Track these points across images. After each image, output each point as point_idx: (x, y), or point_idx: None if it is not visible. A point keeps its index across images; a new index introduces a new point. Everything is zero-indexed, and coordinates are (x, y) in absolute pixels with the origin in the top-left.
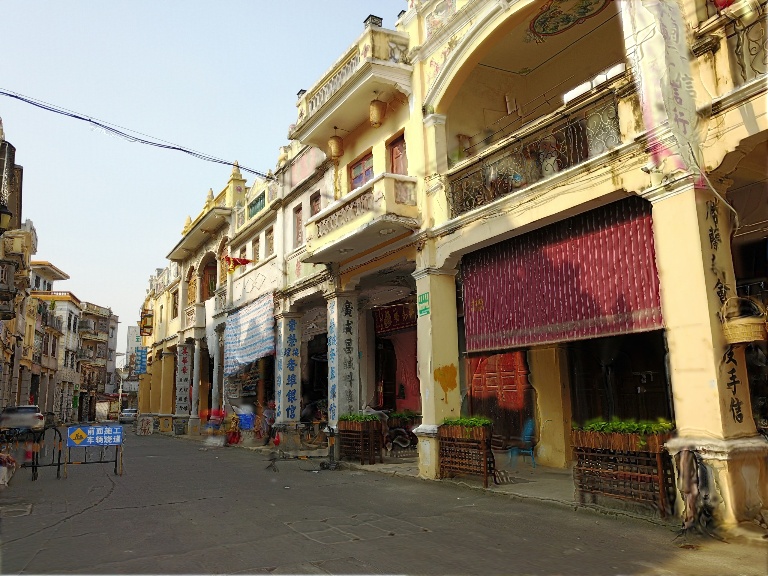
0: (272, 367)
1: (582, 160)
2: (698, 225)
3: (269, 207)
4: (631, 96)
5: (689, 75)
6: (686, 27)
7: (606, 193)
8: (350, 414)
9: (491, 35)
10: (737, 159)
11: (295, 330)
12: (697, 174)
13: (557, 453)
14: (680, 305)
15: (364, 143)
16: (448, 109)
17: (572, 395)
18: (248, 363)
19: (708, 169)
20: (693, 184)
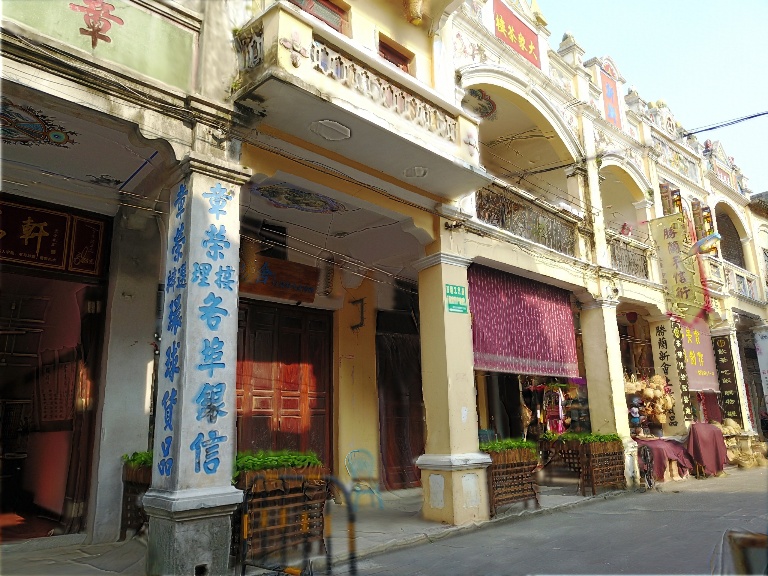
0: None
1: (560, 251)
2: None
3: None
4: None
5: None
6: None
7: (580, 285)
8: None
9: (513, 94)
10: None
11: None
12: None
13: (381, 486)
14: None
15: None
16: None
17: None
18: None
19: None
20: None
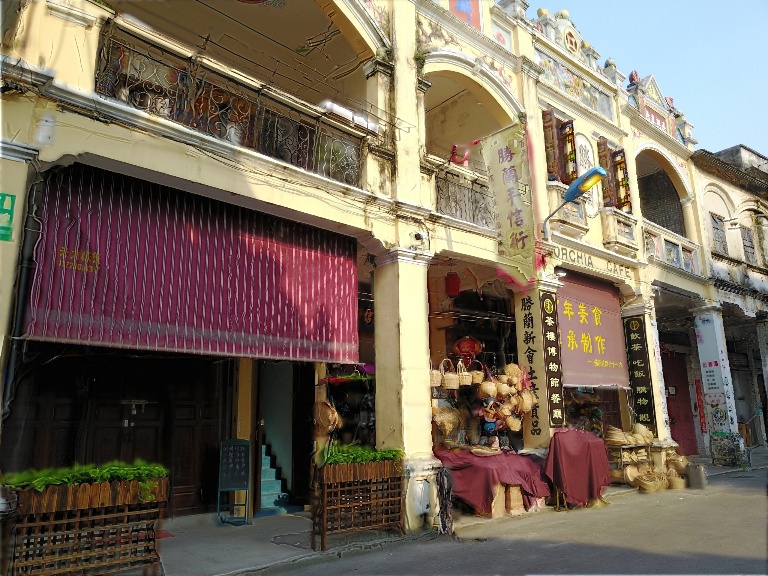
0: None
1: (324, 175)
2: None
3: None
4: (379, 158)
5: None
6: None
7: (357, 226)
8: None
9: None
10: None
11: None
12: None
13: None
14: (414, 351)
15: None
16: None
17: (2, 430)
18: None
19: None
20: None
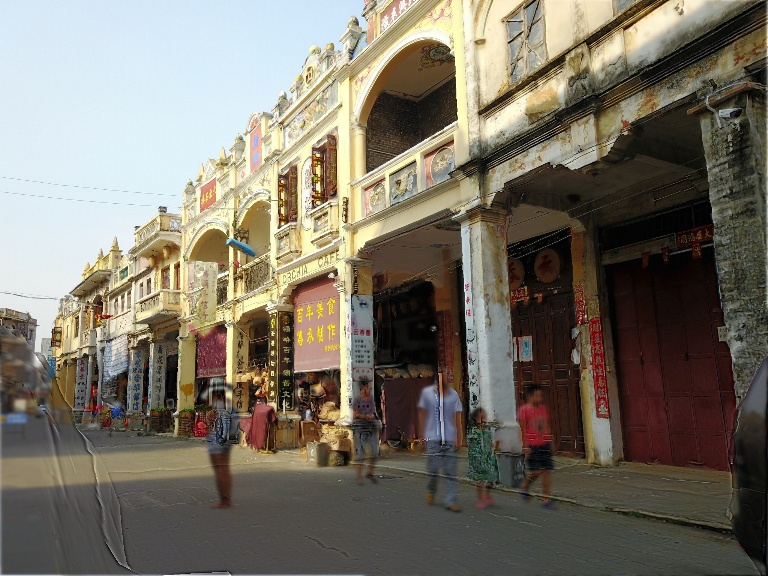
0: (126, 379)
1: None
2: (232, 341)
3: (127, 280)
4: None
5: (207, 301)
6: (213, 282)
7: (222, 320)
8: (158, 407)
9: (204, 235)
10: (246, 318)
11: (140, 357)
12: (233, 323)
13: None
14: (228, 368)
15: (167, 261)
16: (196, 258)
17: None
18: (114, 376)
19: (237, 321)
20: (232, 326)
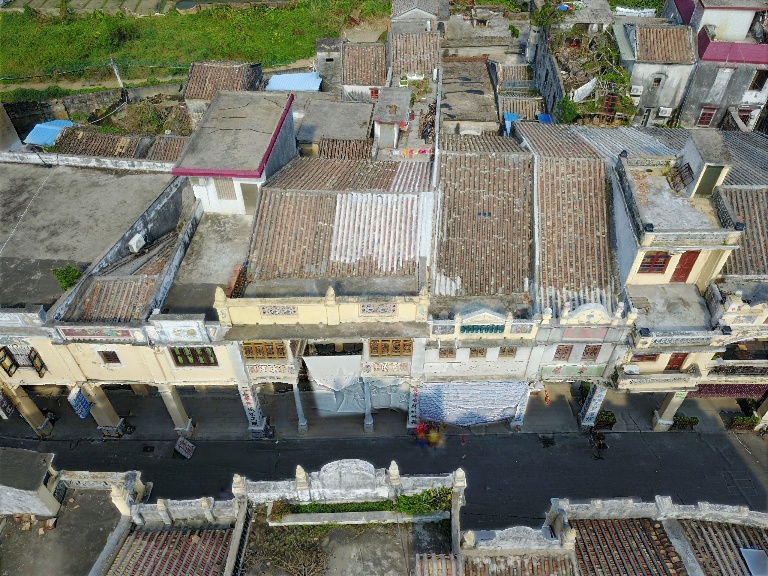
0: None
1: None
2: None
3: None
4: None
5: None
6: None
7: None
8: None
9: None
10: None
11: None
12: None
13: None
14: None
15: None
16: None
17: None
18: None
19: None
20: None
